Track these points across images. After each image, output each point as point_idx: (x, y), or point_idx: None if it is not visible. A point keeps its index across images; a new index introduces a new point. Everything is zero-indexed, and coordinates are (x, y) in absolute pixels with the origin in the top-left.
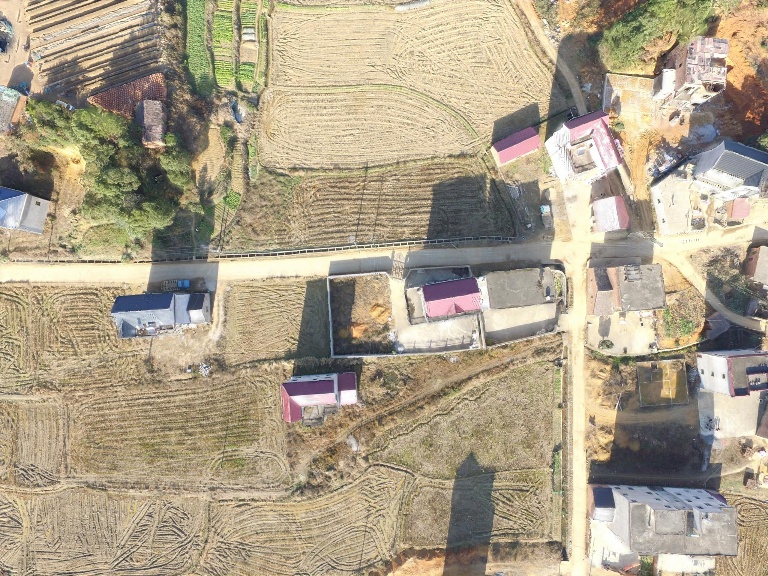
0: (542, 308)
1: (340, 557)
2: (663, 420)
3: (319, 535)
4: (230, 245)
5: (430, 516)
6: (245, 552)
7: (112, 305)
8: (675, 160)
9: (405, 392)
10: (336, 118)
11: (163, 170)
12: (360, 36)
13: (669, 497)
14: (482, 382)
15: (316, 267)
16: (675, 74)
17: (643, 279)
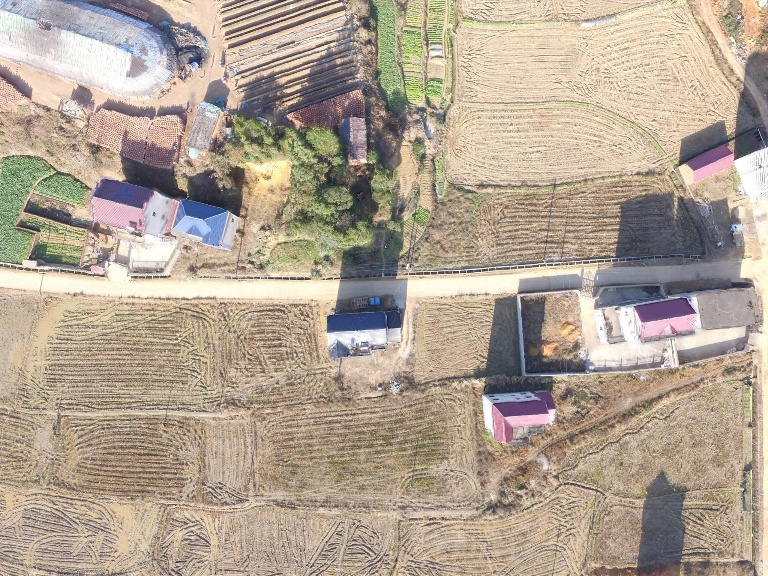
0: None
1: None
2: None
3: (510, 554)
4: (419, 262)
5: (621, 535)
6: (435, 571)
7: (299, 322)
8: None
9: (596, 411)
10: (523, 135)
11: (364, 188)
12: (545, 52)
13: None
14: (672, 401)
15: (505, 285)
16: None
17: None
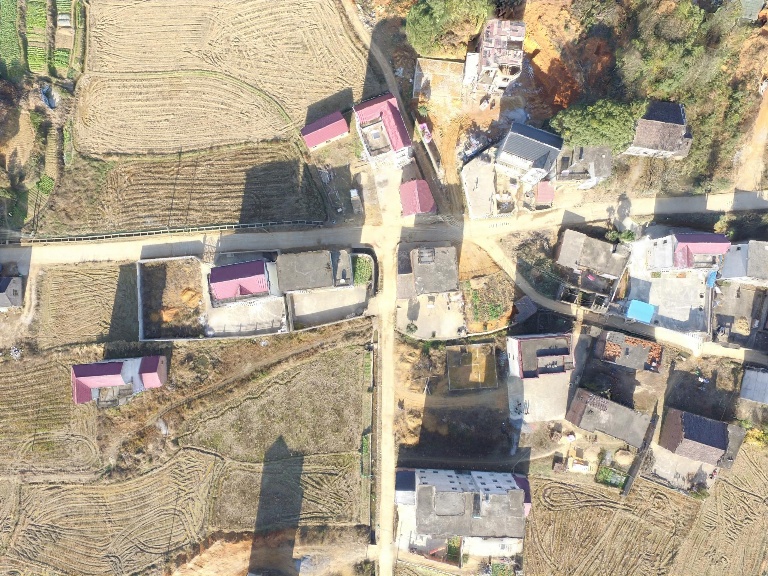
0: (352, 292)
1: (149, 540)
2: (472, 404)
3: (128, 518)
4: (43, 230)
5: (239, 499)
6: (55, 535)
7: None
8: (482, 144)
9: (214, 376)
10: (151, 103)
11: None
12: (177, 22)
13: (466, 480)
14: (292, 366)
15: (128, 251)
16: (478, 58)
17: (437, 262)
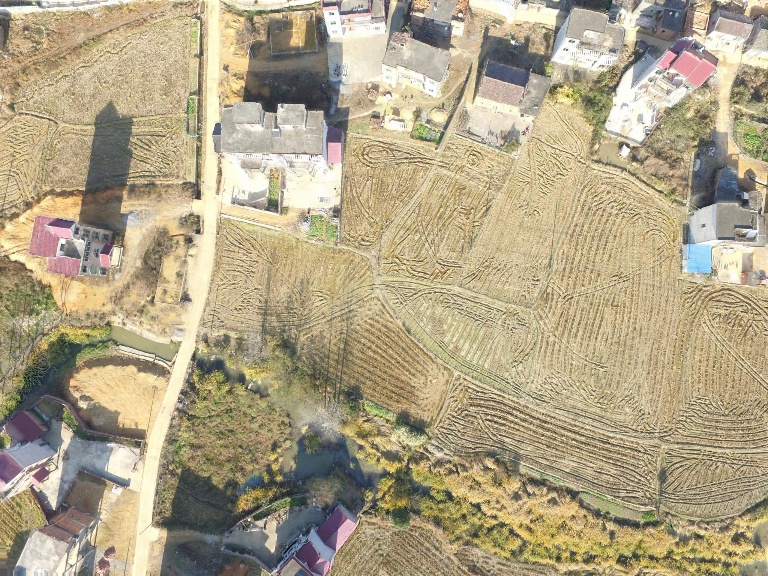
0: None
1: None
2: (294, 68)
3: None
4: None
5: (71, 160)
6: None
7: None
8: None
9: (48, 44)
10: None
11: None
12: None
13: None
14: (123, 36)
15: None
16: None
17: None
